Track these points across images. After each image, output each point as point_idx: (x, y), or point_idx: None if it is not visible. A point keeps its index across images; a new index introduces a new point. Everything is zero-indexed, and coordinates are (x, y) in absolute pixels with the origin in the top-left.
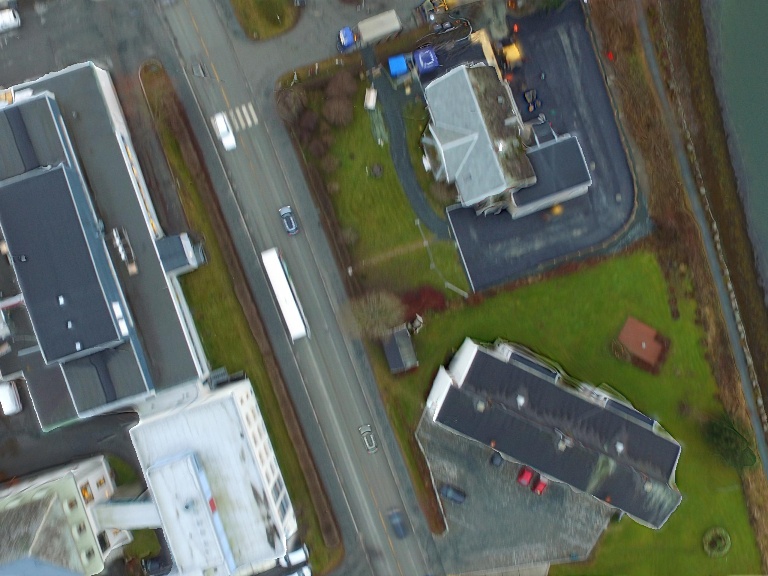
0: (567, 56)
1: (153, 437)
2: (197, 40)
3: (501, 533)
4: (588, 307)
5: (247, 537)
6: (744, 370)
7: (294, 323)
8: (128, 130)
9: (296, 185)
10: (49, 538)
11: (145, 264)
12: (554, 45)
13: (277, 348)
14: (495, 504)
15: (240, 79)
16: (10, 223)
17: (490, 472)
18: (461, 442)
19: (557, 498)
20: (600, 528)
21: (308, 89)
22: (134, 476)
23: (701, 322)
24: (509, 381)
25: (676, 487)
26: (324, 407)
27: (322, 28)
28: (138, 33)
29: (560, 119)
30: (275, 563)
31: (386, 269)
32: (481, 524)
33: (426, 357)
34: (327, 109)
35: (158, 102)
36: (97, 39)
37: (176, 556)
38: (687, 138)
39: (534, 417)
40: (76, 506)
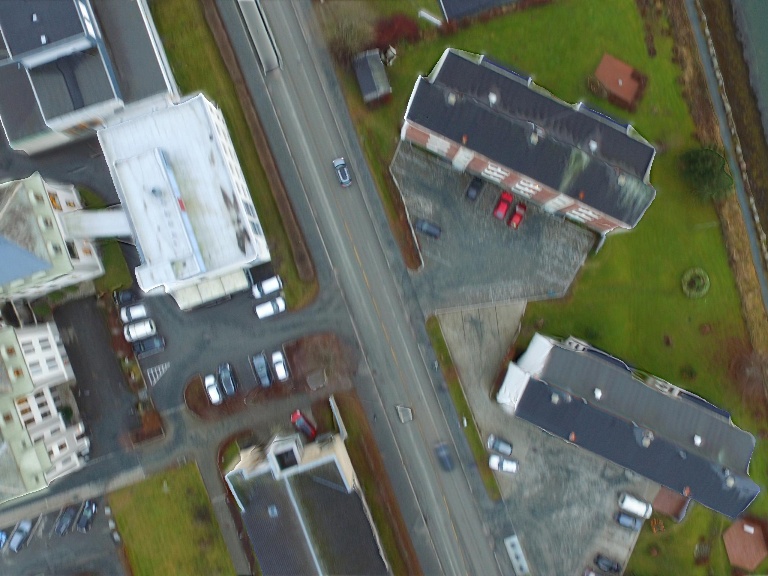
0: None
1: (121, 140)
2: None
3: (477, 269)
4: (564, 42)
5: (217, 241)
6: (722, 118)
7: (266, 54)
8: None
9: None
10: (14, 220)
11: None
12: None
13: (249, 79)
14: (471, 240)
15: None
16: None
17: (466, 208)
18: (436, 178)
19: (534, 234)
20: (577, 264)
21: None
22: (104, 199)
23: (678, 60)
24: (481, 81)
25: (650, 185)
26: (297, 140)
27: None
28: None
29: None
30: (247, 285)
31: None
32: (457, 260)
33: (400, 86)
34: None
35: None
36: None
37: (144, 248)
38: None
39: (506, 114)
40: (43, 202)
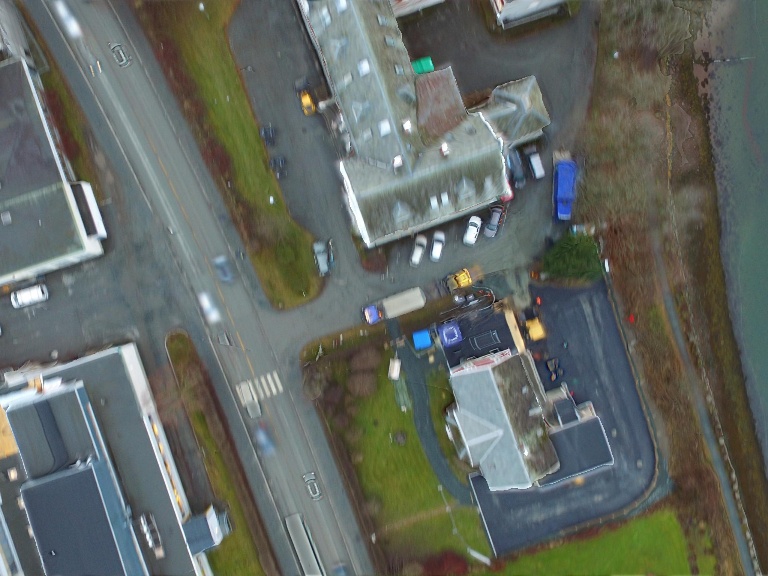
0: (589, 325)
1: None
2: (223, 310)
3: None
4: (608, 566)
5: None
6: None
7: None
8: (154, 402)
9: (320, 452)
10: None
11: (172, 548)
12: (576, 314)
13: None
14: None
15: (265, 348)
16: (40, 523)
17: None
18: None
19: None
20: None
21: (333, 360)
22: None
23: None
24: None
25: None
26: None
27: (346, 297)
28: (164, 303)
29: (582, 387)
30: None
31: (409, 534)
32: None
33: None
34: (352, 383)
35: (184, 371)
36: (124, 309)
37: None
38: (706, 390)
39: None
40: None
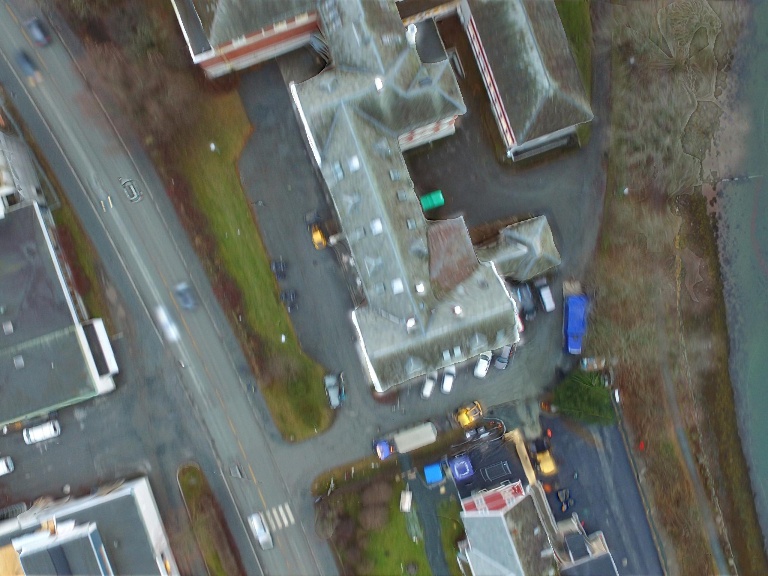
0: (599, 455)
1: None
2: (234, 442)
3: None
4: None
5: None
6: None
7: None
8: (167, 537)
9: None
10: None
11: None
12: (587, 444)
13: None
14: None
15: (277, 480)
16: None
17: None
18: None
19: None
20: None
21: (344, 492)
22: None
23: None
24: None
25: None
26: None
27: (358, 428)
28: (176, 436)
29: (593, 517)
30: None
31: None
32: None
33: None
34: (363, 517)
35: (196, 504)
36: (136, 443)
37: None
38: (716, 511)
39: None
40: None
